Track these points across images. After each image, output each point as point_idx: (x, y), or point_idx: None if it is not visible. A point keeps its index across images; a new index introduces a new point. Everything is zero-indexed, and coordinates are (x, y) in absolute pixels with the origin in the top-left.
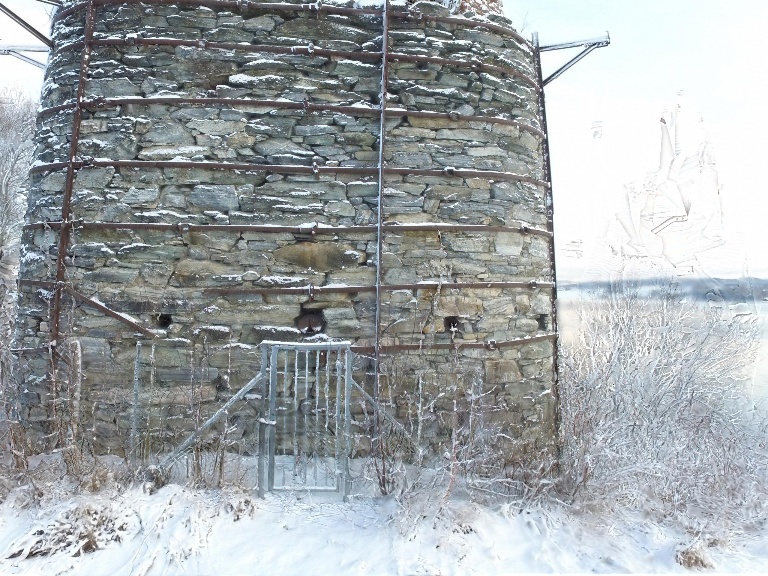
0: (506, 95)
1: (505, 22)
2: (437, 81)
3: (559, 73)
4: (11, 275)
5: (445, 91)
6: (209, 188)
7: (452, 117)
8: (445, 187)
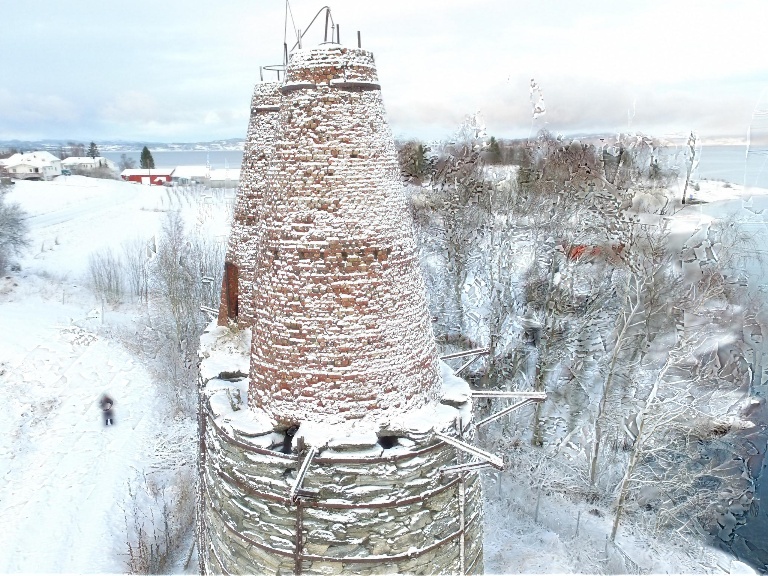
0: None
1: (241, 434)
2: None
3: None
4: (536, 324)
5: None
6: None
7: None
8: None
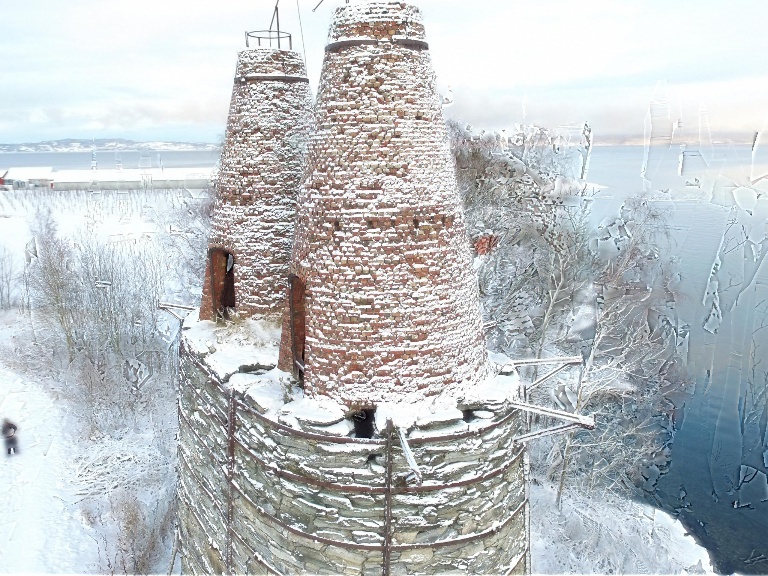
0: (305, 505)
1: (311, 425)
2: (255, 472)
3: (407, 479)
4: None
5: (256, 485)
6: (190, 482)
7: (259, 511)
8: (258, 567)
